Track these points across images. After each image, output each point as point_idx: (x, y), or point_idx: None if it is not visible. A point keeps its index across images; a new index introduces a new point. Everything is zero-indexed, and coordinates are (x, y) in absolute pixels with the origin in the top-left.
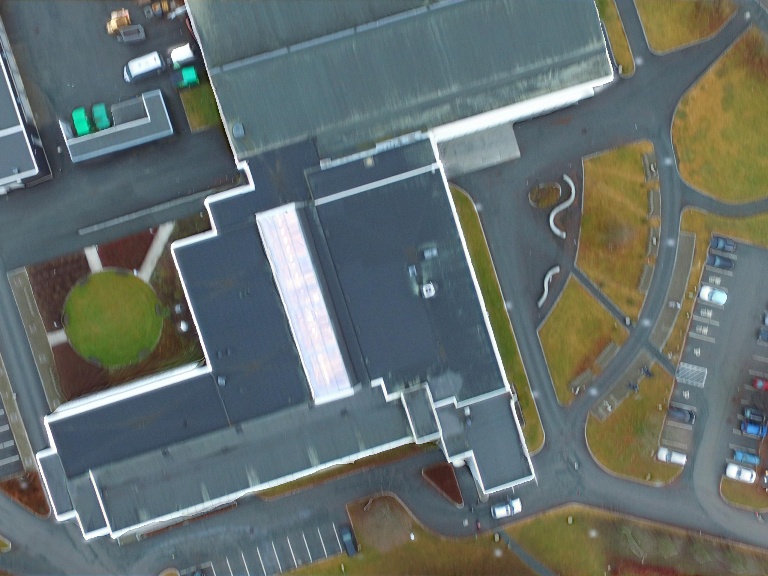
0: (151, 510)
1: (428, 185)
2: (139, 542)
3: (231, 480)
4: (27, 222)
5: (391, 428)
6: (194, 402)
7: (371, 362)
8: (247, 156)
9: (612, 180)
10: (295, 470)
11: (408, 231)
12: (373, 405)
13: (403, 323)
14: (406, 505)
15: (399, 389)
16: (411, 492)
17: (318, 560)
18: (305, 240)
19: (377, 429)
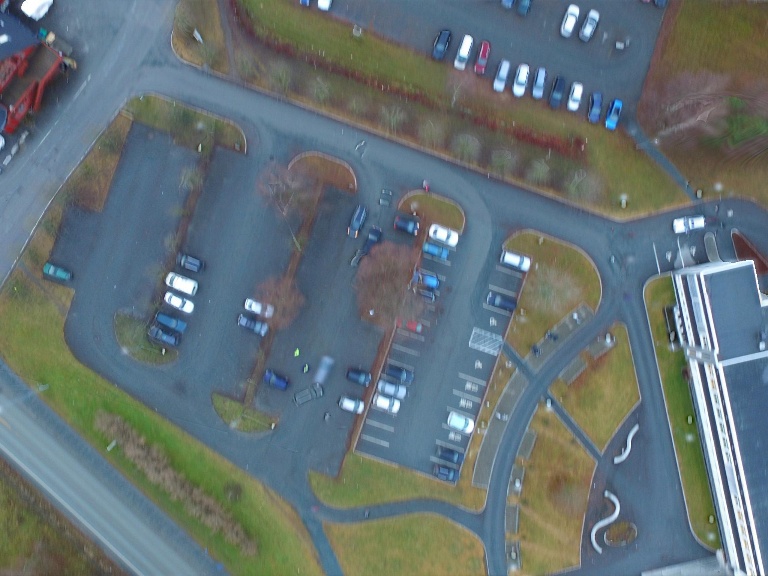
0: None
1: None
2: None
3: None
4: None
5: None
6: None
7: None
8: None
9: (555, 545)
10: None
11: None
12: None
13: None
14: None
15: None
16: None
17: None
18: None
19: None
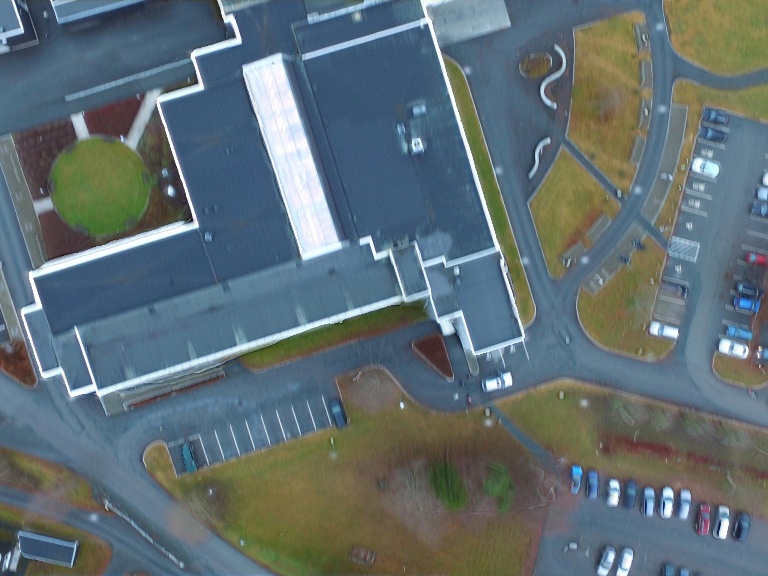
0: (137, 368)
1: (417, 41)
2: (126, 413)
3: (218, 339)
4: (13, 88)
5: (380, 287)
6: (181, 259)
7: (359, 220)
8: (234, 9)
9: (603, 50)
10: (283, 329)
11: (397, 88)
12: (361, 264)
13: (392, 181)
14: (396, 378)
15: (388, 247)
16: (401, 365)
17: (307, 433)
18: (292, 92)
19: (365, 288)
